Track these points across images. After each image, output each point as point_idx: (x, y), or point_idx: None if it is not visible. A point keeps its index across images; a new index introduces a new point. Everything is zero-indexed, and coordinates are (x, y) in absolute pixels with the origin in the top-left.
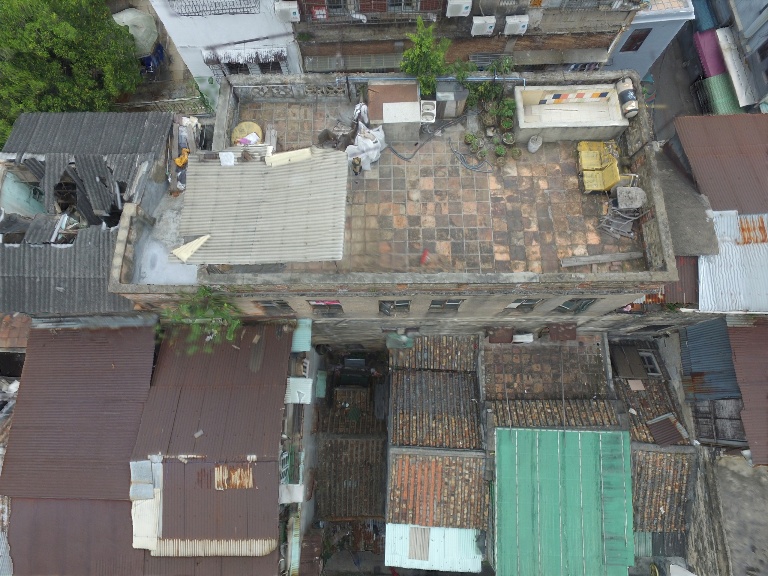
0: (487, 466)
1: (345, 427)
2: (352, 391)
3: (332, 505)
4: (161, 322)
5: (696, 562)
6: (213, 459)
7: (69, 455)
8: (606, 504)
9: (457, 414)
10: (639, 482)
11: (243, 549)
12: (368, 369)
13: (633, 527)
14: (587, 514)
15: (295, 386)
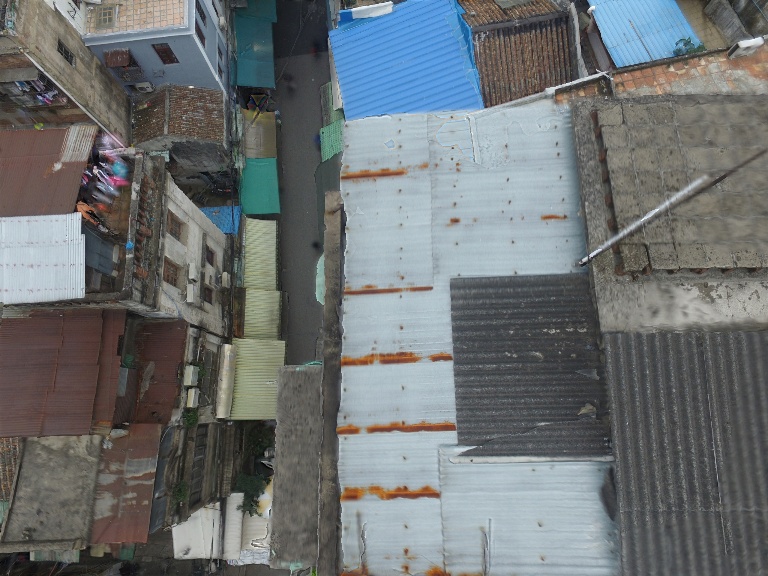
0: None
1: None
2: None
3: None
4: None
5: None
6: None
7: None
8: None
9: None
10: None
11: None
12: None
13: None
14: None
15: None
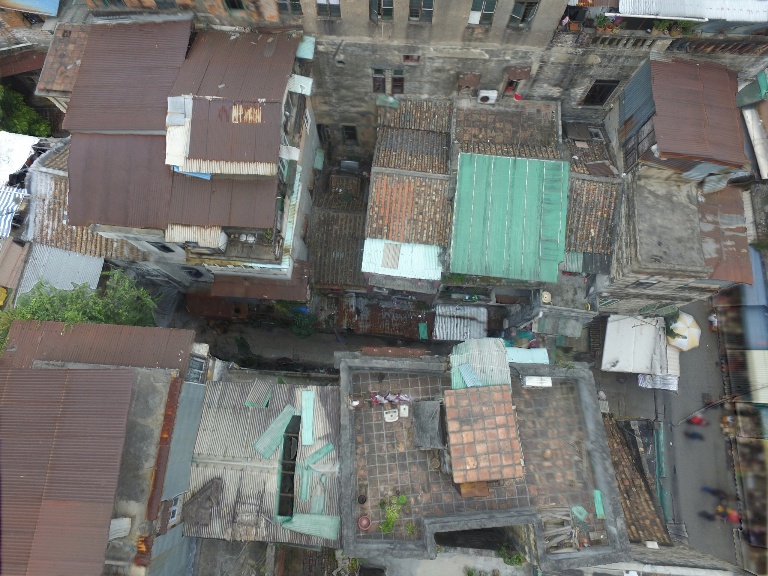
0: (450, 184)
1: (337, 205)
2: (345, 178)
3: (321, 273)
4: (195, 26)
5: (616, 270)
6: (232, 99)
7: (119, 103)
8: (545, 215)
9: (430, 154)
10: (575, 206)
11: (250, 169)
12: (361, 172)
13: (568, 246)
14: (529, 221)
15: (299, 81)
